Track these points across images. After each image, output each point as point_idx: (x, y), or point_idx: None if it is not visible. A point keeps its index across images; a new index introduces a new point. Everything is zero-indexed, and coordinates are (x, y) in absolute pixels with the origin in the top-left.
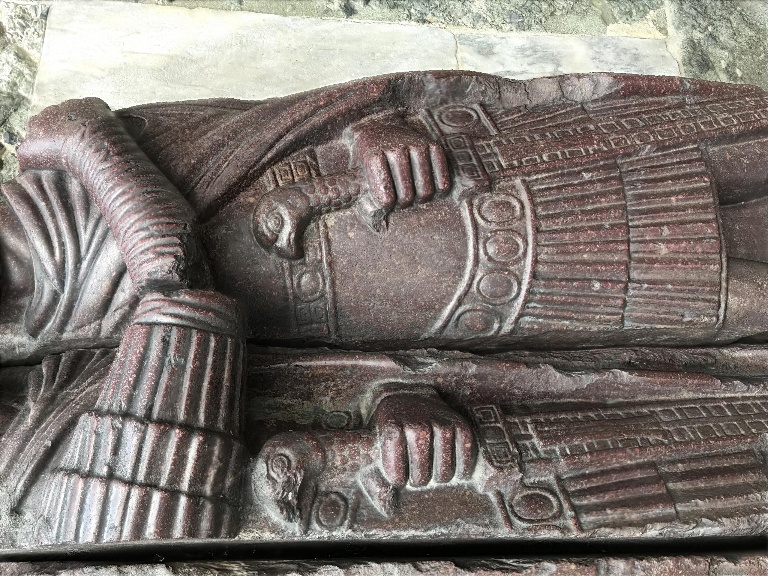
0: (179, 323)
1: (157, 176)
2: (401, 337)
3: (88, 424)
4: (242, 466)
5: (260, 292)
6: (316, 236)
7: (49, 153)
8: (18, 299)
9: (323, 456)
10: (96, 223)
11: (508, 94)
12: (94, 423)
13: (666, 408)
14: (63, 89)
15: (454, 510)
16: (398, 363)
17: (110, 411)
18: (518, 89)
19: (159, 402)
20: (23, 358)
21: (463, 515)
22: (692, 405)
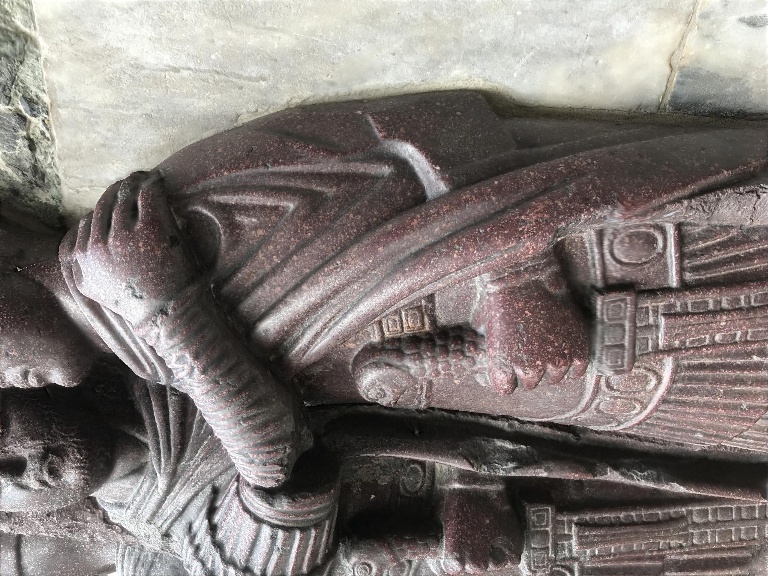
0: (284, 525)
1: (250, 389)
2: None
3: (215, 555)
4: None
5: (354, 398)
6: None
7: None
8: None
9: None
10: None
11: (725, 211)
12: (221, 566)
13: (703, 508)
14: (78, 30)
15: (491, 575)
16: (476, 467)
17: (232, 559)
18: (744, 204)
19: (271, 570)
20: None
21: None
22: (729, 506)
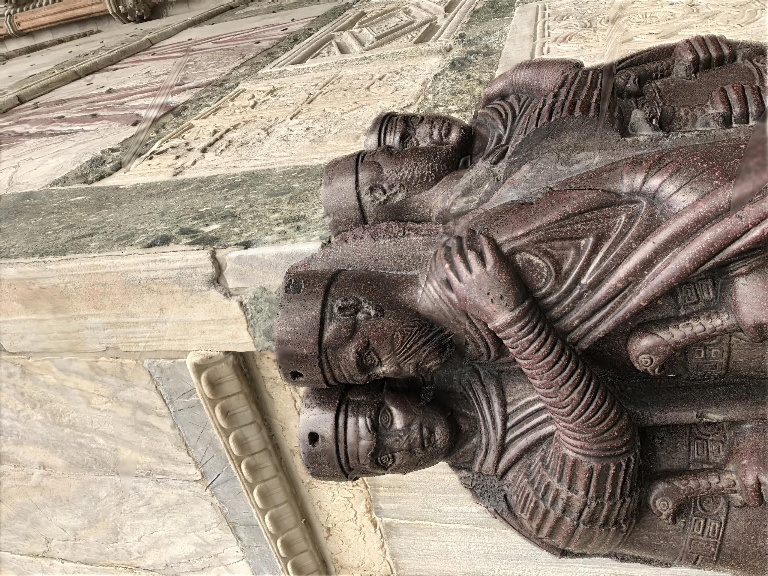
0: None
1: None
2: None
3: None
4: (622, 118)
5: None
6: (651, 88)
7: (502, 82)
8: (477, 154)
9: (672, 107)
10: (525, 102)
11: None
12: None
13: None
14: None
15: None
16: None
17: None
18: None
19: None
20: None
21: None
22: None
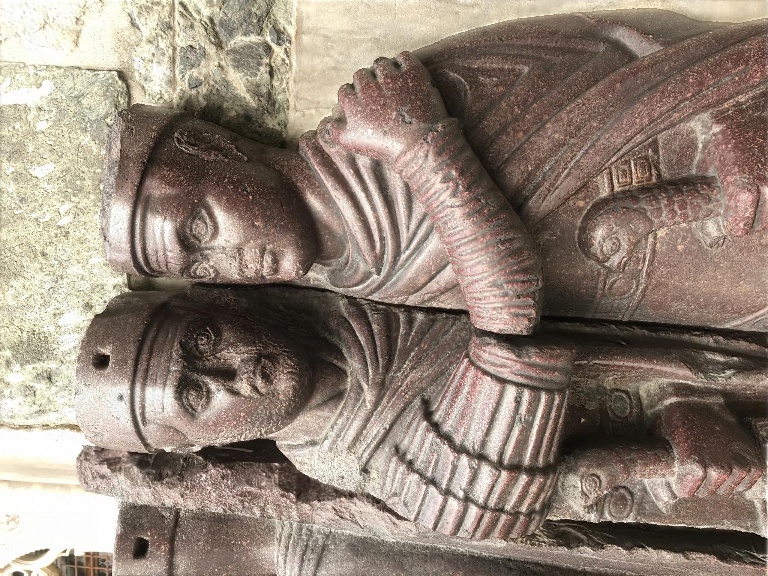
0: (529, 384)
1: (506, 214)
2: (691, 324)
3: (441, 450)
4: None
5: (569, 289)
6: (643, 247)
7: (377, 154)
8: (325, 260)
9: None
10: (419, 223)
11: None
12: (451, 457)
13: None
14: None
15: (722, 512)
16: (694, 372)
17: (463, 447)
18: None
19: (510, 452)
20: (316, 287)
21: (729, 517)
22: None
